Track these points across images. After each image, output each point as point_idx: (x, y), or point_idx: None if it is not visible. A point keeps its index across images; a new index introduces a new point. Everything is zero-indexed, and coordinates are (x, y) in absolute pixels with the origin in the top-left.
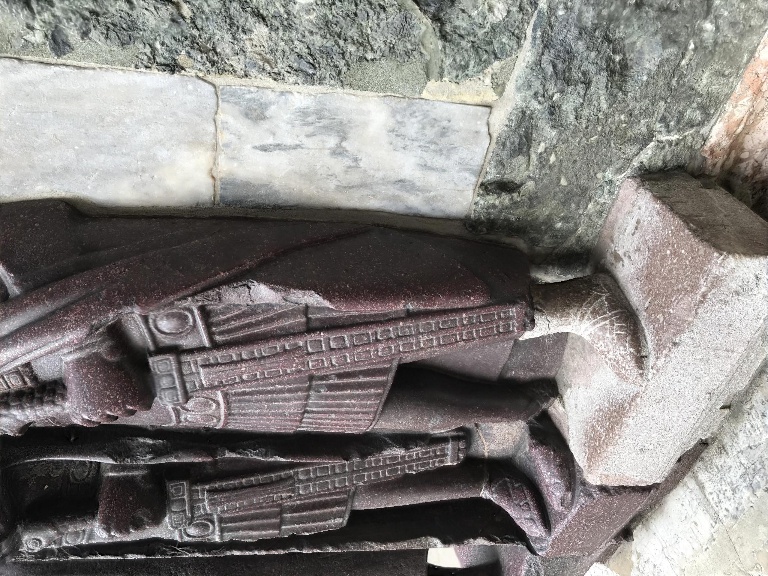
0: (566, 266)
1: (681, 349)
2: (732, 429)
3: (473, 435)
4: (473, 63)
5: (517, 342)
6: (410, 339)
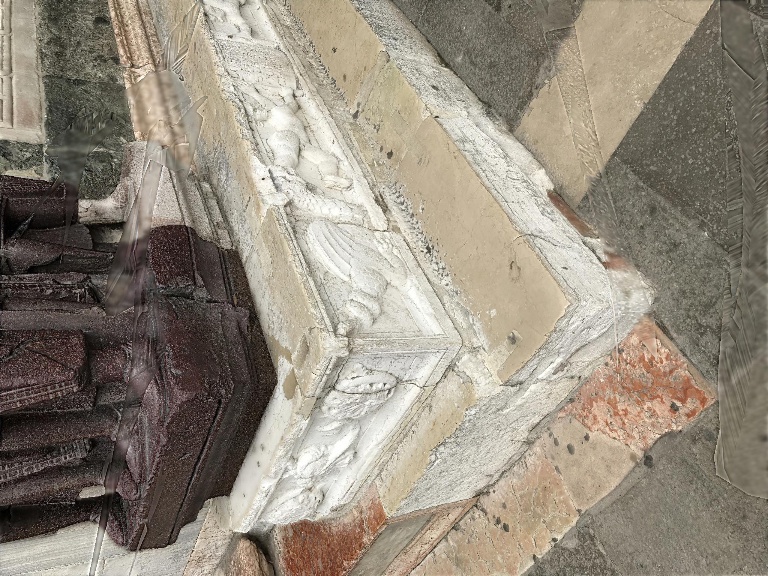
0: (111, 226)
1: (137, 166)
2: (235, 234)
3: (97, 293)
4: (24, 166)
5: (99, 247)
6: (8, 187)
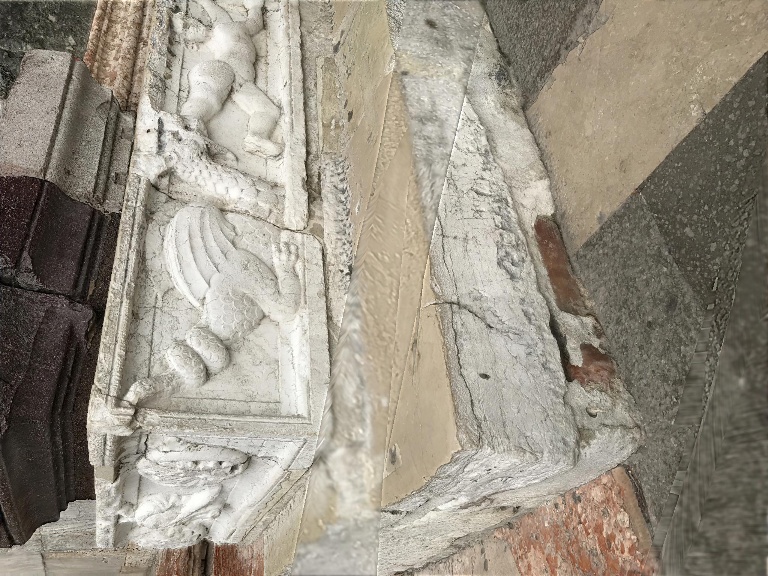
0: None
1: None
2: None
3: None
4: None
5: None
6: None
